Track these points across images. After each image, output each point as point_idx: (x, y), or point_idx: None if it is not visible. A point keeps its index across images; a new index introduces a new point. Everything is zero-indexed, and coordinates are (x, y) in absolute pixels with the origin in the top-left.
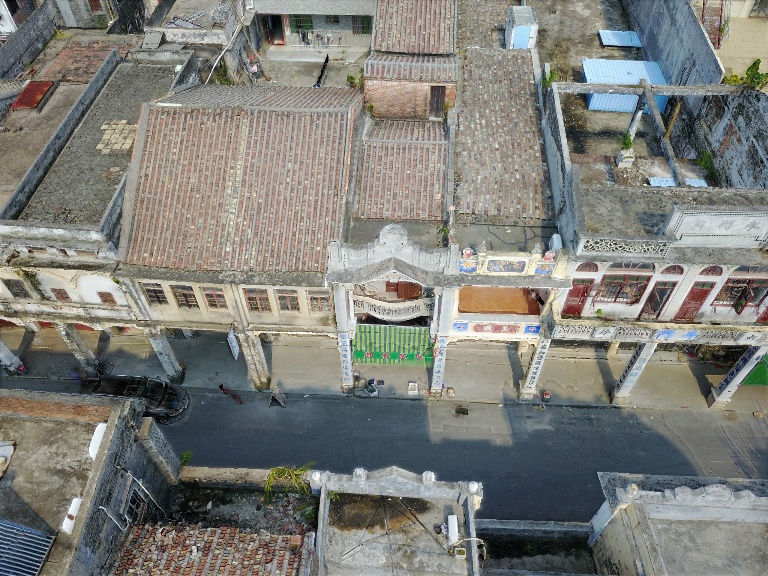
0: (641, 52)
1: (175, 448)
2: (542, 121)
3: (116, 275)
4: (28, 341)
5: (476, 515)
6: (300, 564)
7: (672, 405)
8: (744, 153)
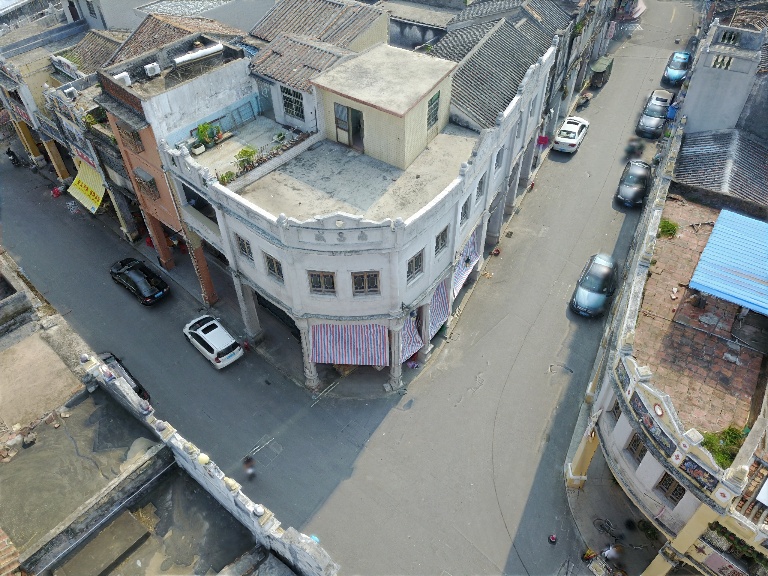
0: None
1: (132, 344)
2: None
3: (15, 265)
4: None
5: (57, 223)
6: (115, 54)
7: None
8: None
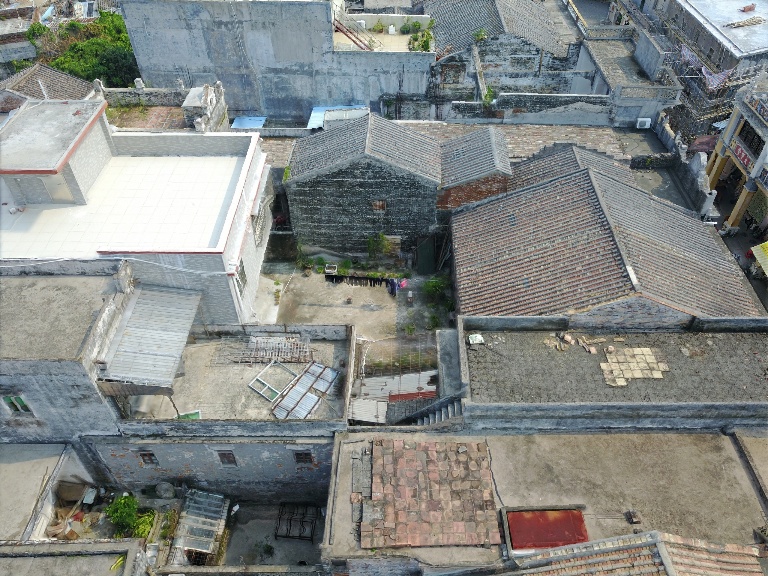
0: (270, 120)
1: None
2: (506, 121)
3: None
4: None
5: None
6: None
7: None
8: (509, 67)
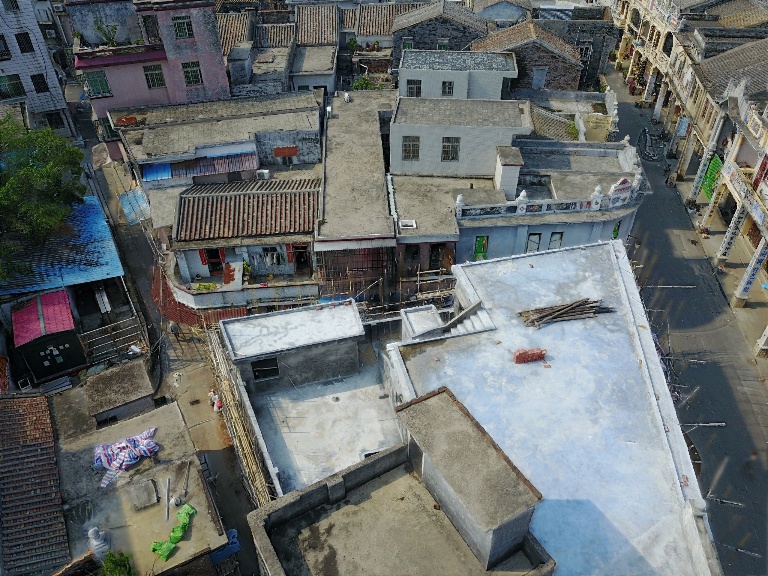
0: None
1: None
2: None
3: (692, 65)
4: (672, 122)
5: None
6: None
7: (745, 331)
8: None
